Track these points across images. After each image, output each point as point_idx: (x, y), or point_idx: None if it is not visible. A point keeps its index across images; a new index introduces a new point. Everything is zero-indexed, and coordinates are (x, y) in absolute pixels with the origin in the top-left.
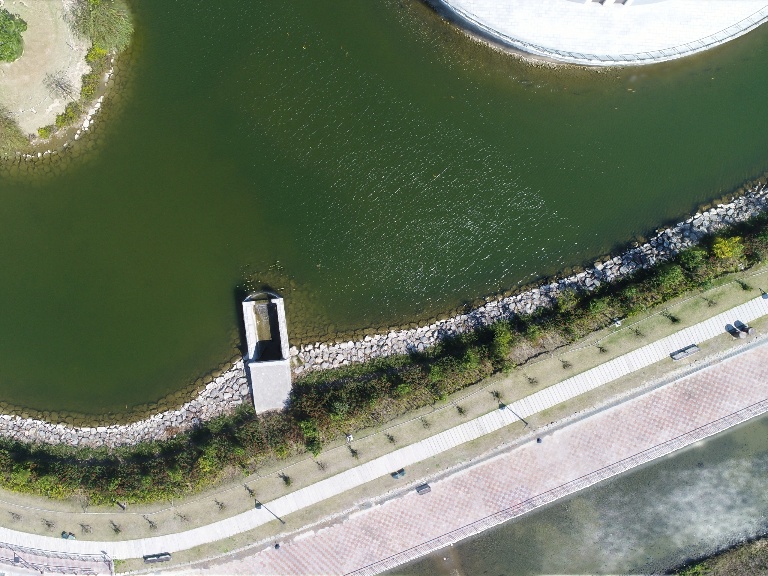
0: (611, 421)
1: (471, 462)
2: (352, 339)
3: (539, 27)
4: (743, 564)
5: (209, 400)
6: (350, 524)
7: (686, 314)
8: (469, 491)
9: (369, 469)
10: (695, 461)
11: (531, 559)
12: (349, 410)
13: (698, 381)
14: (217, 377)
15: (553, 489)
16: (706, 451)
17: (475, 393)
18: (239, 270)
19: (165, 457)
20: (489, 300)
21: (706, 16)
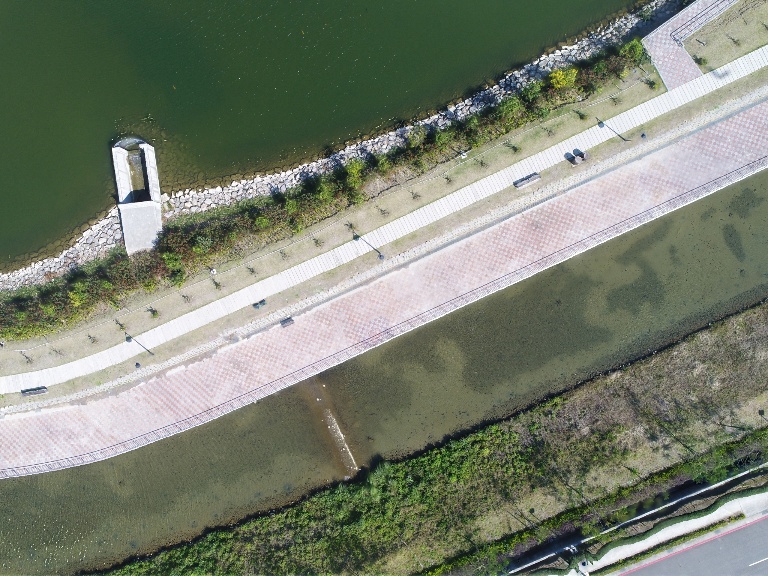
0: (463, 252)
1: (332, 296)
2: (220, 185)
3: None
4: (598, 394)
5: (85, 246)
6: (219, 358)
7: (527, 144)
8: (330, 323)
9: (232, 301)
10: (553, 299)
11: (400, 398)
12: (212, 245)
13: (544, 212)
14: (93, 225)
15: (410, 319)
16: (564, 290)
17: (330, 225)
18: (113, 124)
19: (42, 297)
20: (349, 144)
21: None
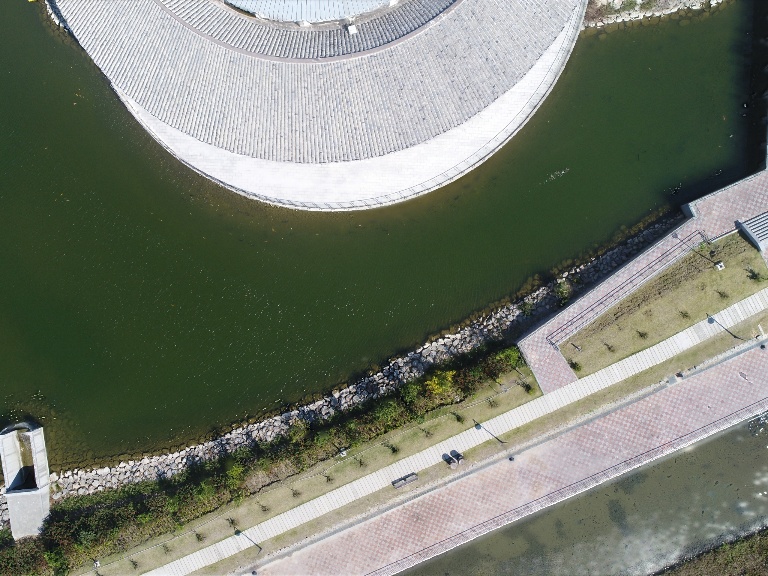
0: (345, 542)
1: None
2: (108, 465)
3: (261, 177)
4: None
5: None
6: None
7: (406, 444)
8: None
9: None
10: (442, 571)
11: None
12: (96, 538)
13: (425, 504)
14: None
15: None
16: (452, 561)
17: (212, 520)
18: (4, 400)
19: None
20: (235, 427)
21: (416, 166)
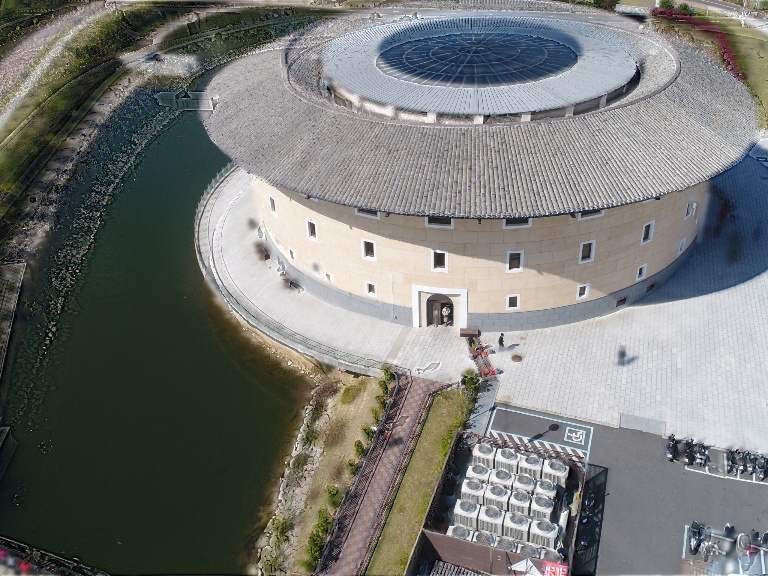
0: None
1: None
2: None
3: None
4: None
5: None
6: None
7: (27, 200)
8: None
9: (87, 107)
10: None
11: None
12: None
13: None
14: None
15: None
16: None
17: (85, 133)
18: None
19: None
20: None
21: None
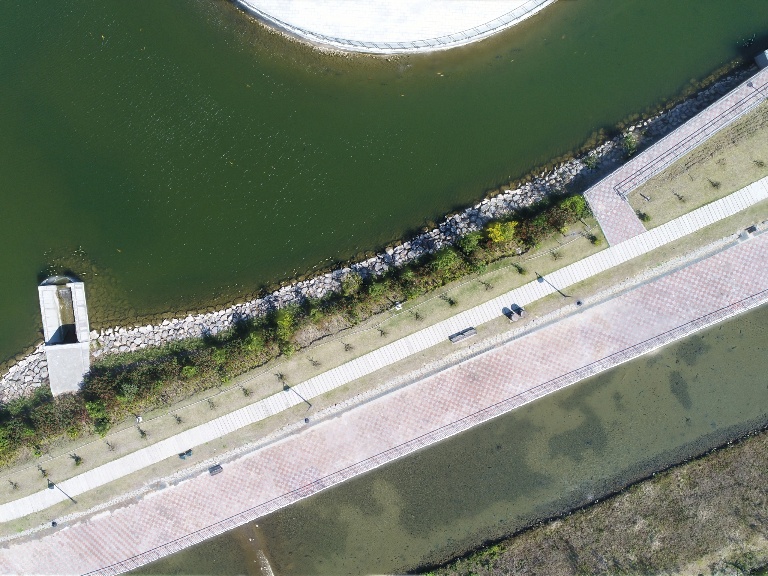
0: (397, 403)
1: (262, 443)
2: (151, 323)
3: (319, 15)
4: (537, 545)
5: (11, 383)
6: (145, 504)
7: (464, 297)
8: (260, 472)
9: (158, 450)
10: (494, 444)
11: (335, 540)
12: (138, 392)
13: (482, 364)
14: (20, 360)
15: (342, 470)
16: (505, 434)
17: (260, 375)
18: (43, 255)
19: None
20: (284, 285)
21: (481, 4)
